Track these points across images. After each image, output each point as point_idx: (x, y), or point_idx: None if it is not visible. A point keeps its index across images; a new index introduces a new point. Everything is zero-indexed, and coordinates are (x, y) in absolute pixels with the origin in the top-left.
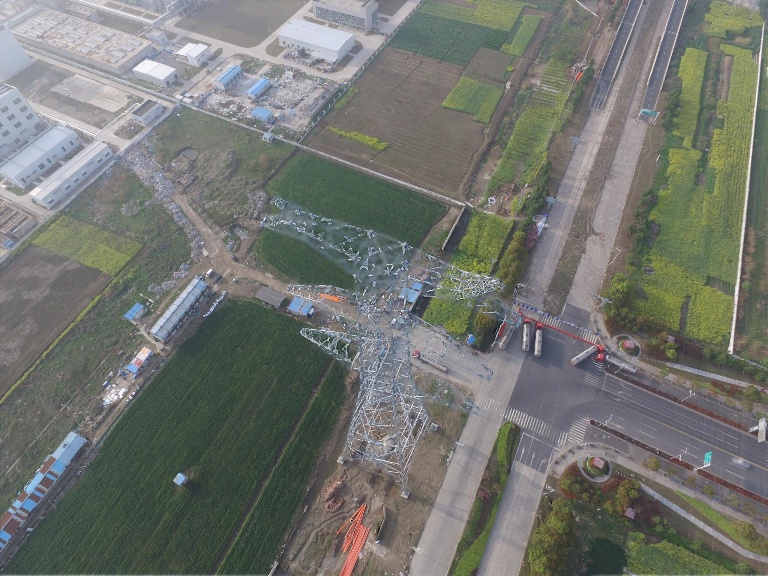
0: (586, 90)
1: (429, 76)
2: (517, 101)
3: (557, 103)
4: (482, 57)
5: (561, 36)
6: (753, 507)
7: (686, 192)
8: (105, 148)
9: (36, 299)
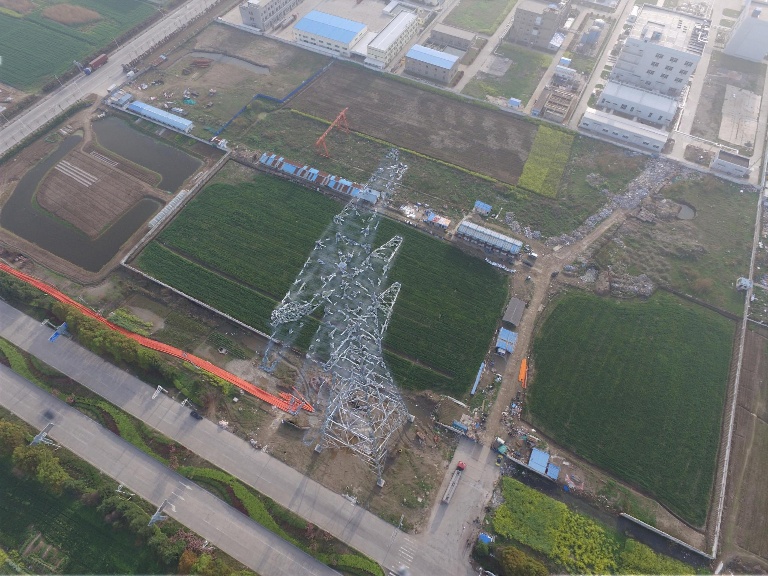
0: None
1: None
2: None
3: None
4: None
5: None
6: None
7: None
8: (662, 142)
9: (488, 143)
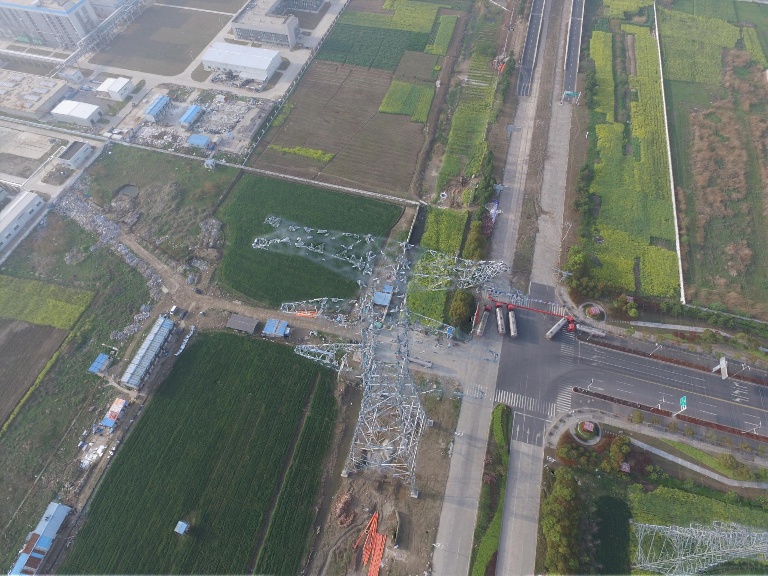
0: (511, 80)
1: (361, 84)
2: (449, 98)
3: (487, 95)
4: (408, 60)
5: (478, 32)
6: (729, 439)
7: (617, 163)
8: (35, 197)
9: None
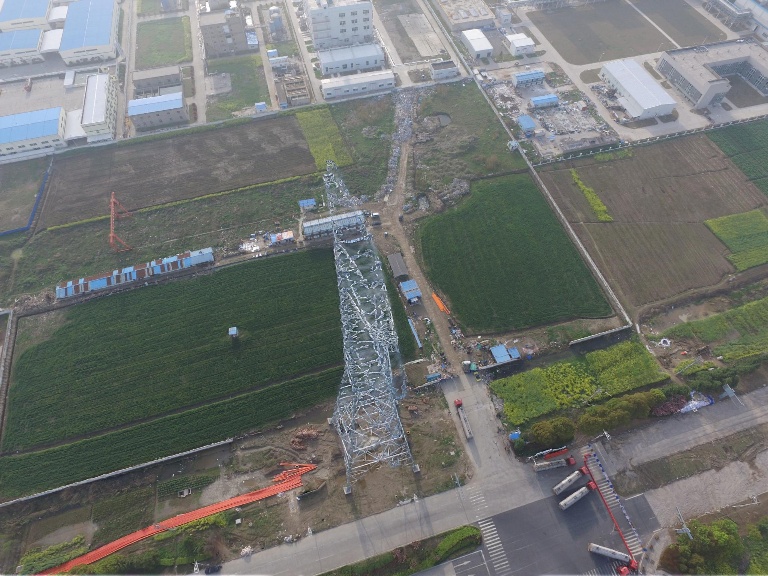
0: None
1: (720, 186)
2: None
3: None
4: None
5: None
6: None
7: None
8: (392, 78)
9: (267, 151)
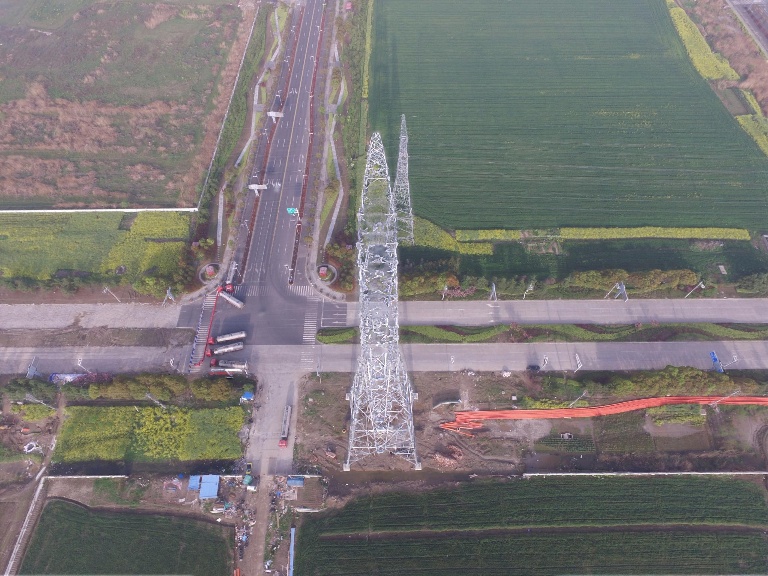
0: None
1: None
2: None
3: None
4: None
5: None
6: None
7: (6, 255)
8: None
9: None
